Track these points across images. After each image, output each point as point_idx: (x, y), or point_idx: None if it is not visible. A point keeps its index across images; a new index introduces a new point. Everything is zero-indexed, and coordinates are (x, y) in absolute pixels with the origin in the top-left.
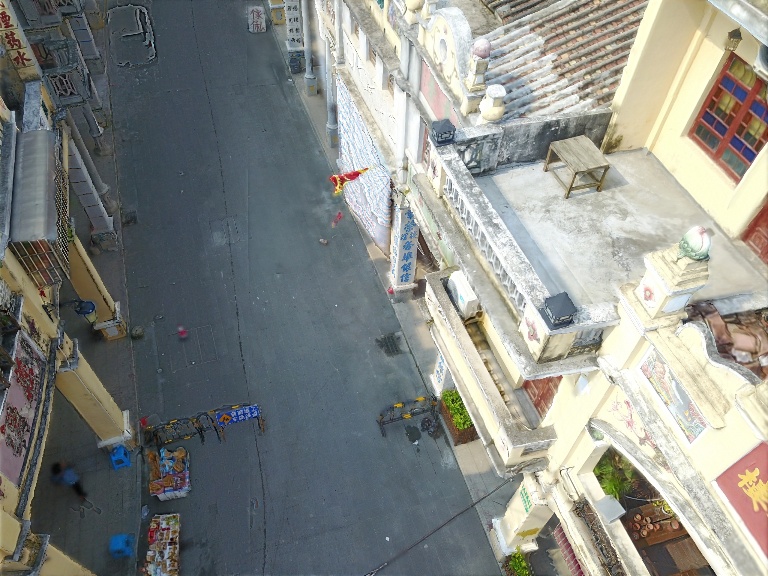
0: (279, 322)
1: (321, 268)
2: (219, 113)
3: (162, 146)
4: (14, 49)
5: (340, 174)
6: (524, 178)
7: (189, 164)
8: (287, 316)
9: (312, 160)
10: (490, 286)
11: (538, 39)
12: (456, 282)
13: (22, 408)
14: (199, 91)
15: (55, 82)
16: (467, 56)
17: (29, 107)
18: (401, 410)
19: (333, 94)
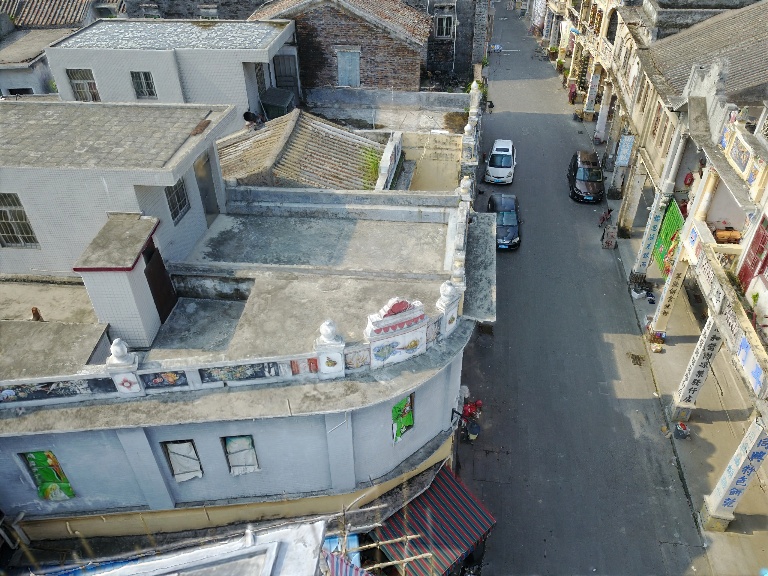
0: None
1: None
2: None
3: None
4: None
5: None
6: None
7: None
8: None
9: (523, 30)
10: None
11: None
12: None
13: None
14: None
15: None
16: None
17: None
18: None
19: None
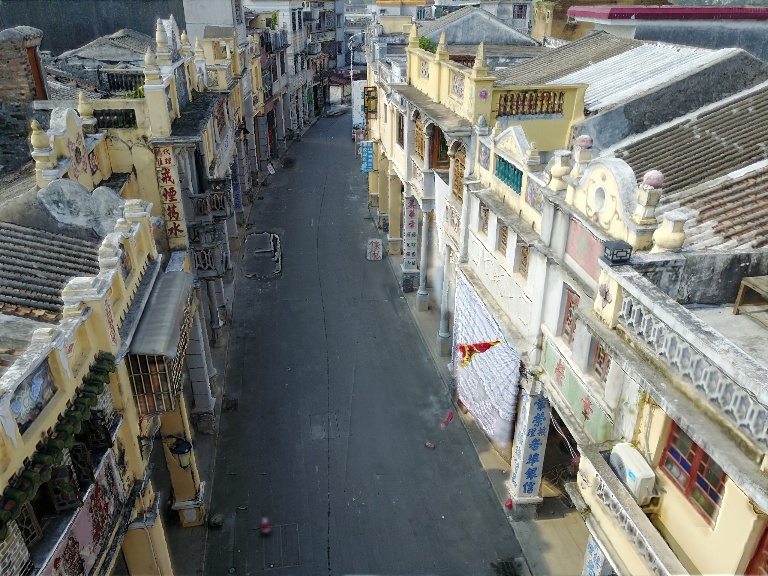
0: (375, 529)
1: (426, 473)
2: (332, 320)
3: (273, 344)
4: (171, 220)
5: (451, 378)
6: (711, 319)
7: (297, 361)
8: (385, 523)
9: (420, 366)
10: (702, 417)
11: (691, 211)
12: (622, 455)
13: (84, 547)
14: (315, 301)
15: (197, 256)
16: (631, 196)
17: (171, 268)
18: None
19: (448, 301)
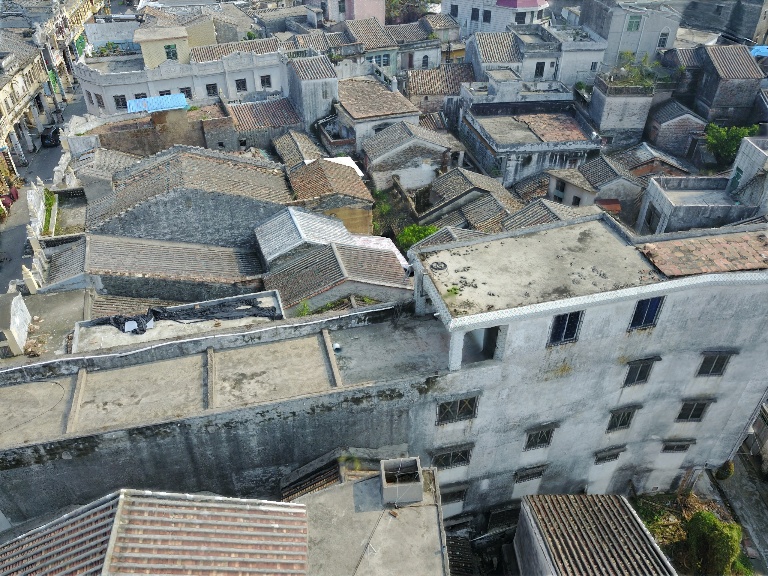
0: None
1: None
2: None
3: None
4: None
5: None
6: None
7: None
8: None
9: None
10: None
11: None
12: None
13: None
14: None
15: None
16: None
17: None
18: (3, 263)
19: None
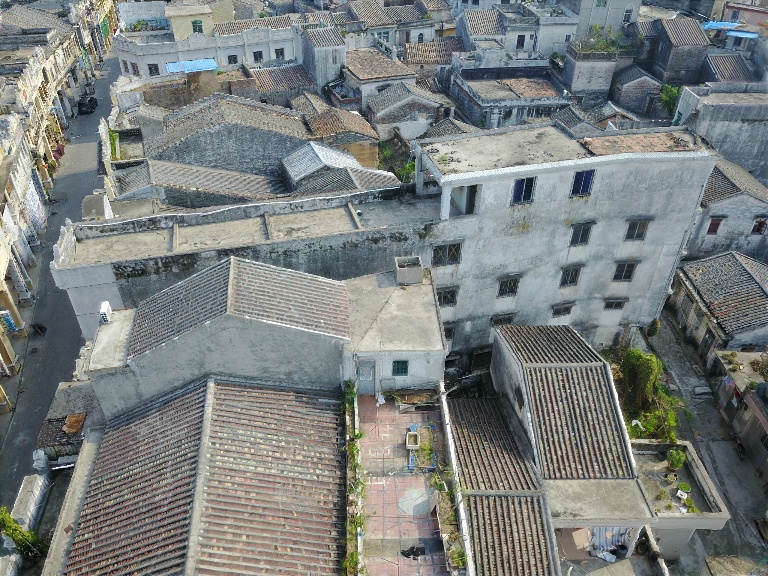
0: None
1: None
2: None
3: None
4: None
5: None
6: None
7: None
8: None
9: (49, 260)
10: None
11: None
12: None
13: None
14: None
15: None
16: None
17: None
18: None
19: None
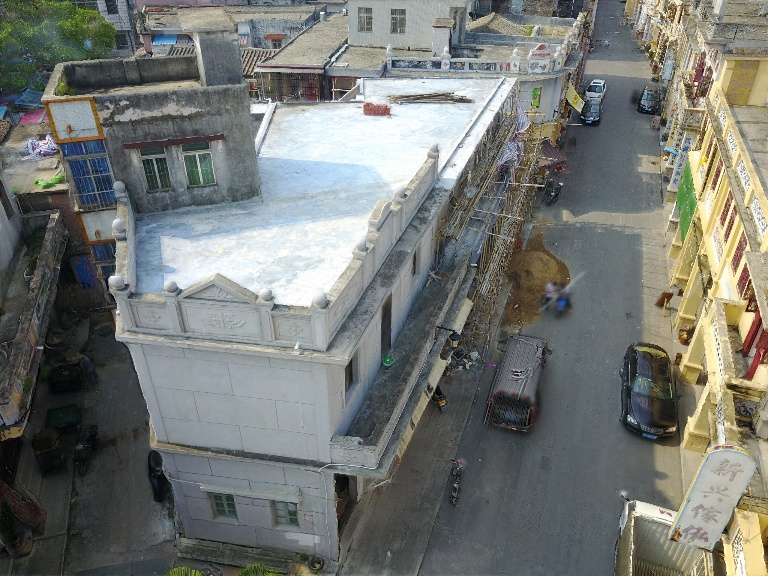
0: None
1: None
2: None
3: None
4: None
5: (637, 34)
6: None
7: None
8: None
9: None
10: None
11: None
12: None
13: None
14: None
15: None
16: None
17: None
18: None
19: None
